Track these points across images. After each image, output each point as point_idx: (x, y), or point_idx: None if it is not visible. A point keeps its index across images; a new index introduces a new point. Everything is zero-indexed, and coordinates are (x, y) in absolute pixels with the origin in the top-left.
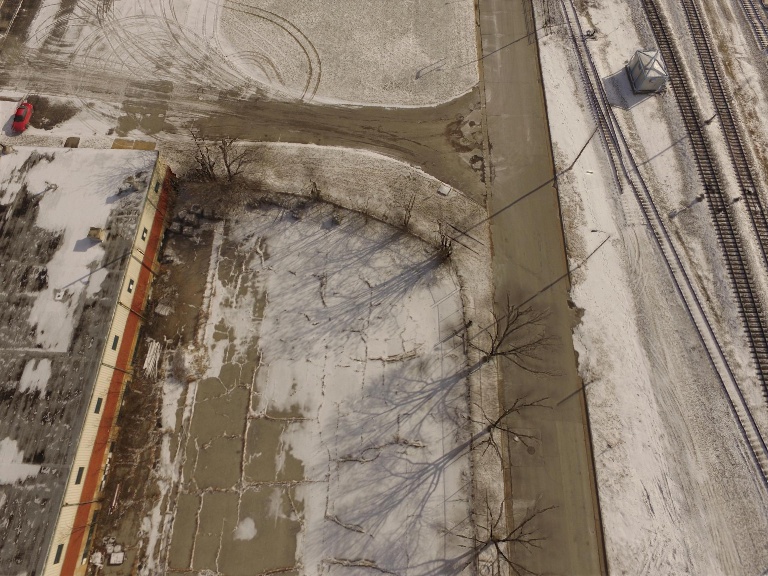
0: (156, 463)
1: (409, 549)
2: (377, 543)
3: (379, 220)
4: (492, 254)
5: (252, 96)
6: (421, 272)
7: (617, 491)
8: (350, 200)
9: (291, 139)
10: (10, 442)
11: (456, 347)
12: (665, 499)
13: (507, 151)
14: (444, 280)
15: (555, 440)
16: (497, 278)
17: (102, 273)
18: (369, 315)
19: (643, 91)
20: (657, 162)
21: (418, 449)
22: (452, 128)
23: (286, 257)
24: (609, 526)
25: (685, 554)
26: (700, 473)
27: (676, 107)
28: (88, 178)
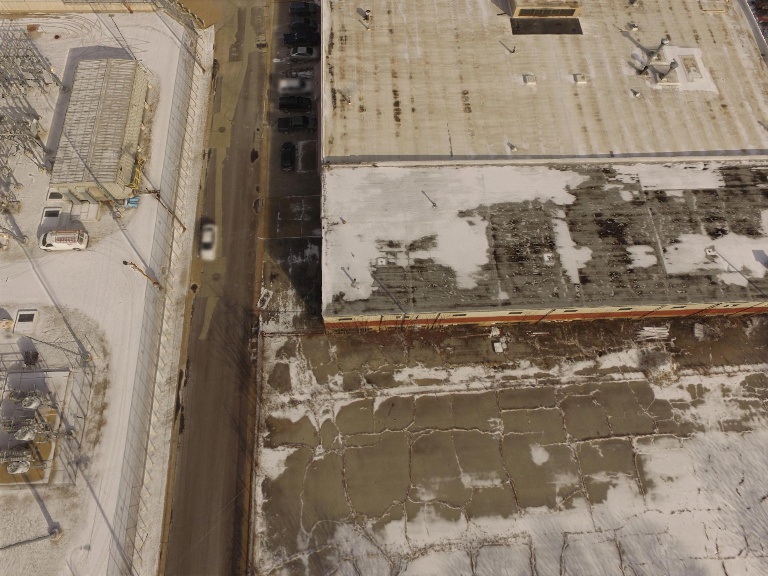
0: (571, 360)
1: None
2: None
3: None
4: None
5: None
6: None
7: None
8: None
9: None
10: (590, 254)
11: None
12: None
13: None
14: None
15: None
16: None
17: (743, 281)
18: None
19: None
20: None
21: None
22: None
23: None
24: None
25: None
26: None
27: None
28: None
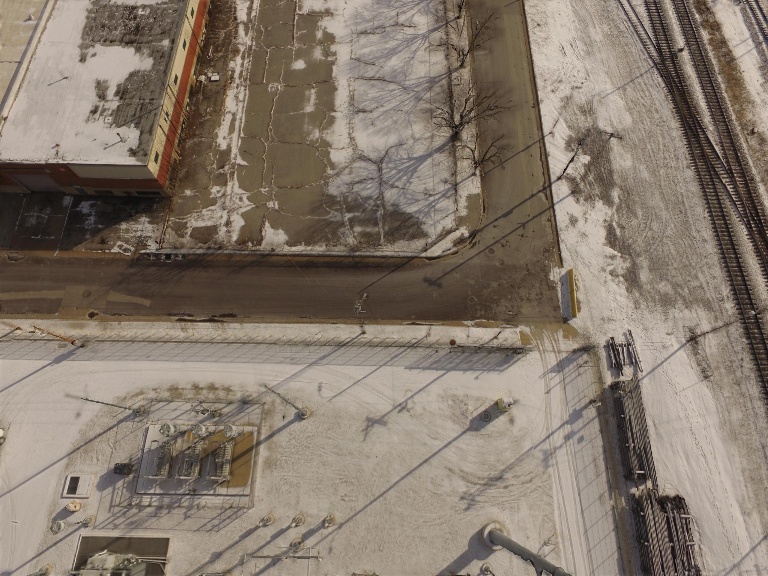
0: (236, 37)
1: (406, 72)
2: (385, 70)
3: None
4: None
5: None
6: None
7: (543, 45)
8: None
9: None
10: None
11: None
12: (574, 49)
13: None
14: None
15: (503, 23)
16: None
17: None
18: None
19: None
20: None
21: (411, 28)
22: None
23: None
24: (537, 60)
25: (585, 72)
26: (597, 36)
27: None
28: None
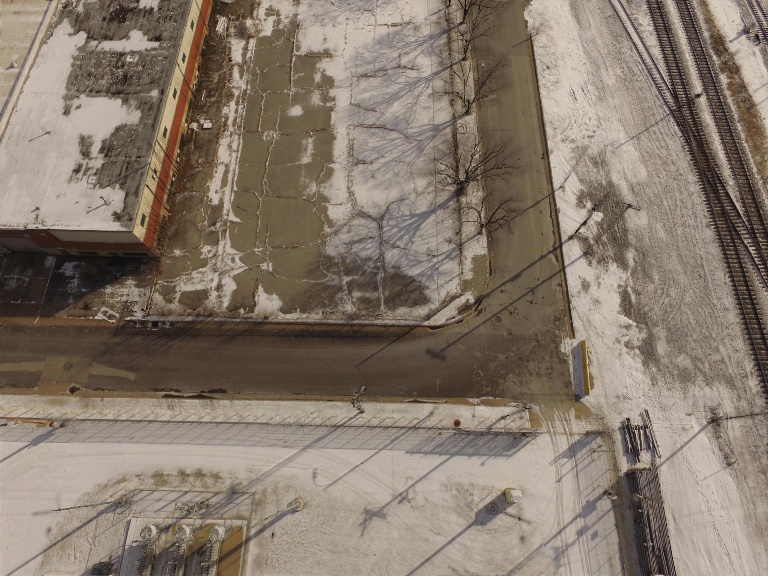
0: (230, 80)
1: (409, 119)
2: (387, 117)
3: None
4: None
5: None
6: None
7: (552, 89)
8: None
9: None
10: (137, 31)
11: (440, 18)
12: (585, 94)
13: None
14: None
15: (510, 65)
16: None
17: None
18: (377, 2)
19: None
20: None
21: (414, 70)
22: None
23: None
24: (546, 106)
25: (597, 120)
26: (610, 80)
27: None
28: None
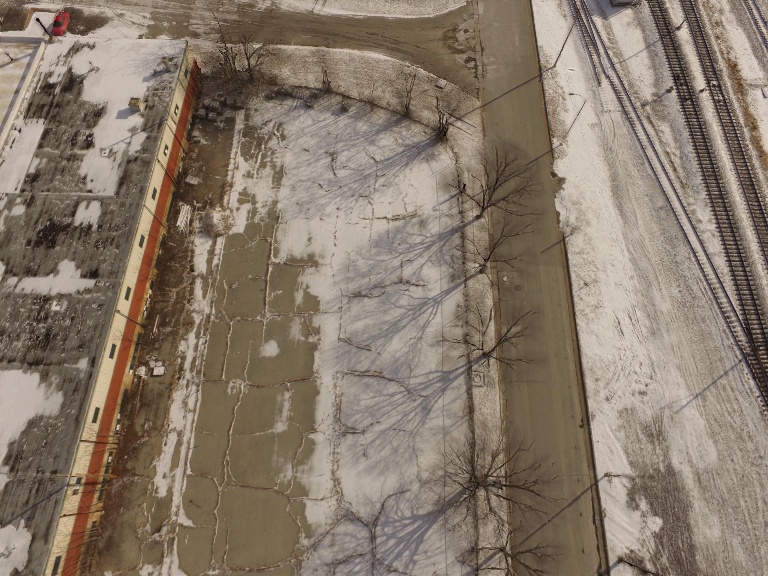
0: (190, 299)
1: (412, 363)
2: (384, 359)
3: (383, 108)
4: (484, 135)
5: (267, 8)
6: (421, 149)
7: (592, 318)
8: (357, 92)
9: (303, 43)
10: (68, 263)
11: (452, 208)
12: (634, 325)
13: (498, 53)
14: (441, 156)
15: (539, 280)
16: (488, 154)
17: (142, 135)
18: (375, 183)
19: (620, 3)
20: (632, 62)
21: (419, 287)
22: (448, 34)
23: (301, 138)
24: (585, 345)
25: (650, 366)
26: (664, 304)
27: (650, 16)
28: (126, 62)
